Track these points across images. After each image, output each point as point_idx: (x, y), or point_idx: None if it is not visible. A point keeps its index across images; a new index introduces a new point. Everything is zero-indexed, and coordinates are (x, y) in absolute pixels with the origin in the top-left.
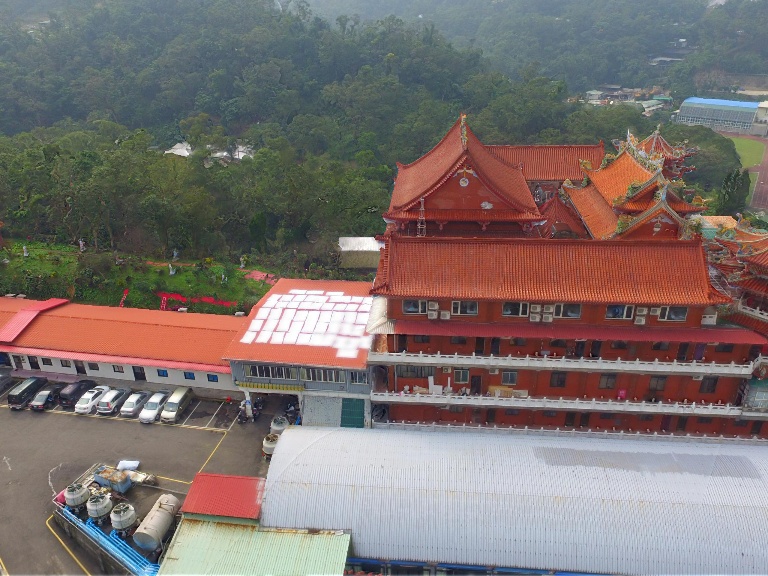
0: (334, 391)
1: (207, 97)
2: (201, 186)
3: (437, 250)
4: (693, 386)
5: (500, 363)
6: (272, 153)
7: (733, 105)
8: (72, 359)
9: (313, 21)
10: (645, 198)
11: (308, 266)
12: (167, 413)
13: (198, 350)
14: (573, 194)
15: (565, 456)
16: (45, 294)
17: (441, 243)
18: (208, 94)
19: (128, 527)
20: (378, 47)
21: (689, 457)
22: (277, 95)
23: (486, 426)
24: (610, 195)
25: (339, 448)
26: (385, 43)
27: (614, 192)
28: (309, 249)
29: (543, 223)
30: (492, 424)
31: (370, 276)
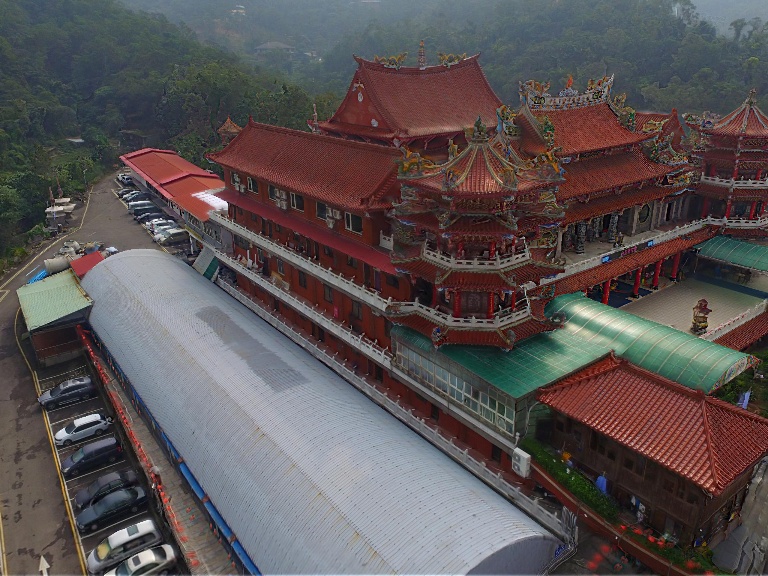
0: None
1: None
2: None
3: (263, 135)
4: (379, 324)
5: (256, 240)
6: None
7: None
8: None
9: (698, 26)
10: None
11: None
12: (163, 237)
13: None
14: None
15: (214, 316)
16: None
17: (269, 130)
18: None
19: None
20: (760, 53)
21: (273, 358)
22: None
23: (262, 307)
24: None
25: None
26: (767, 48)
27: None
28: None
29: (394, 142)
30: (277, 312)
31: None
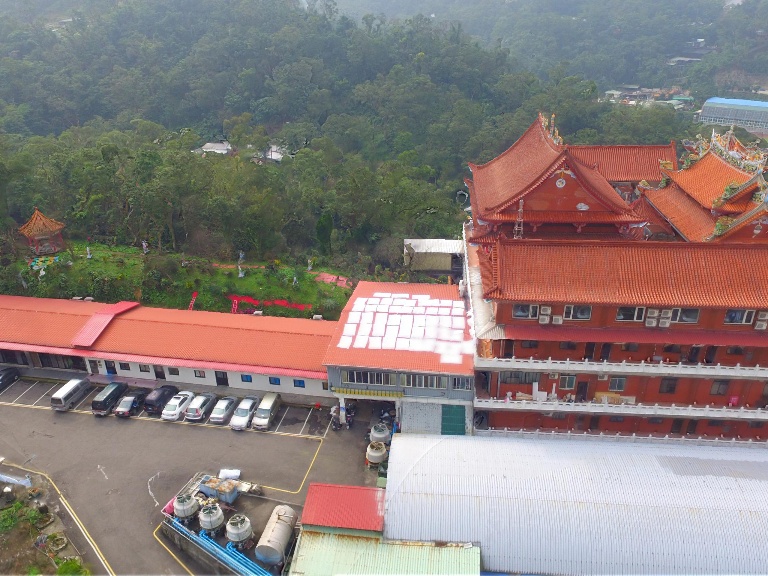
0: (434, 397)
1: (237, 96)
2: (256, 186)
3: (547, 253)
4: None
5: (613, 369)
6: (313, 153)
7: (756, 105)
8: (152, 364)
9: (339, 20)
10: (743, 199)
11: (369, 268)
12: (259, 420)
13: (285, 355)
14: (651, 195)
15: (692, 465)
16: (111, 297)
17: (551, 246)
18: (237, 93)
19: (245, 539)
20: (406, 46)
21: None
22: (309, 94)
23: (592, 433)
24: (702, 196)
25: (455, 457)
26: (413, 42)
27: (706, 193)
28: (370, 251)
29: None
30: (595, 431)
31: (442, 278)
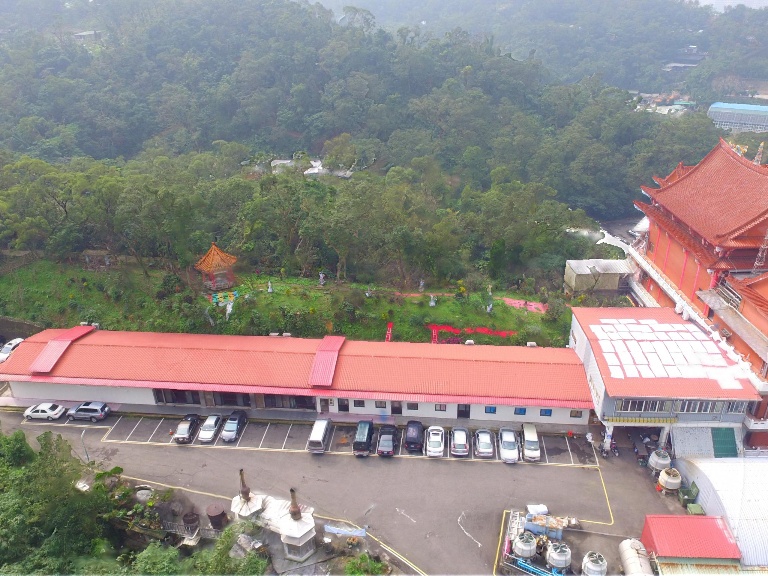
0: (706, 421)
1: (289, 112)
2: None
3: None
4: None
5: None
6: None
7: (760, 110)
8: (391, 400)
9: (376, 33)
10: None
11: None
12: (531, 452)
13: (533, 385)
14: None
15: None
16: (302, 331)
17: None
18: (289, 109)
19: (605, 575)
20: (446, 59)
21: None
22: (369, 110)
23: None
24: None
25: None
26: (454, 55)
27: None
28: (523, 272)
29: None
30: None
31: (624, 299)
